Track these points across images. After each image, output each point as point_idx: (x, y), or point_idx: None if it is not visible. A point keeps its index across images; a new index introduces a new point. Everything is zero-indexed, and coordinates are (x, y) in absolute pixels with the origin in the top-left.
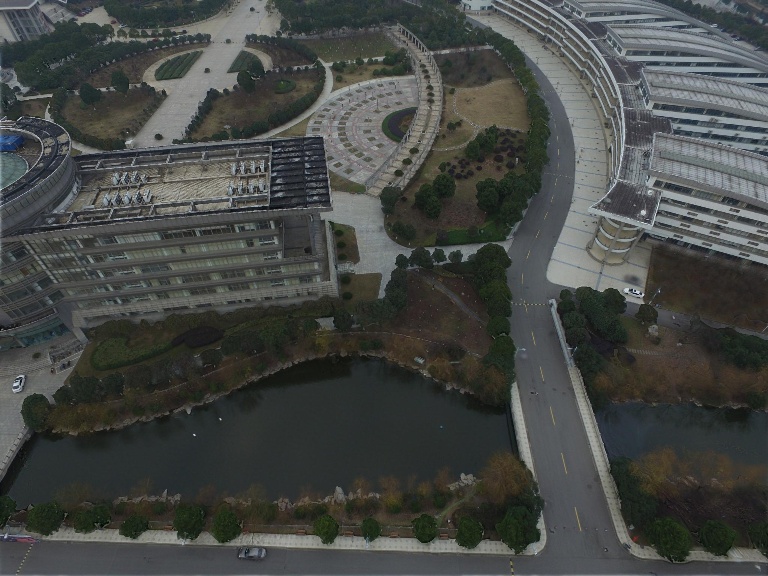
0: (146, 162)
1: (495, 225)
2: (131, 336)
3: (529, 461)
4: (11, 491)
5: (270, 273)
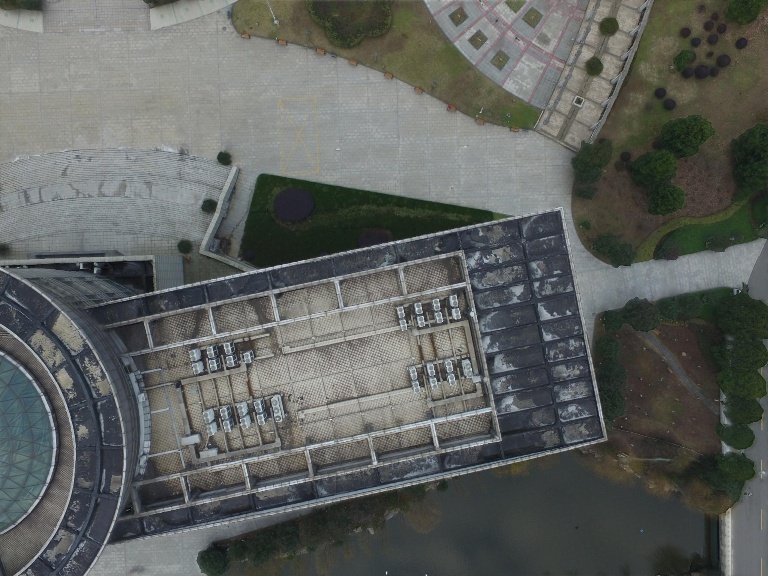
0: None
1: (748, 210)
2: None
3: (728, 569)
4: None
5: None
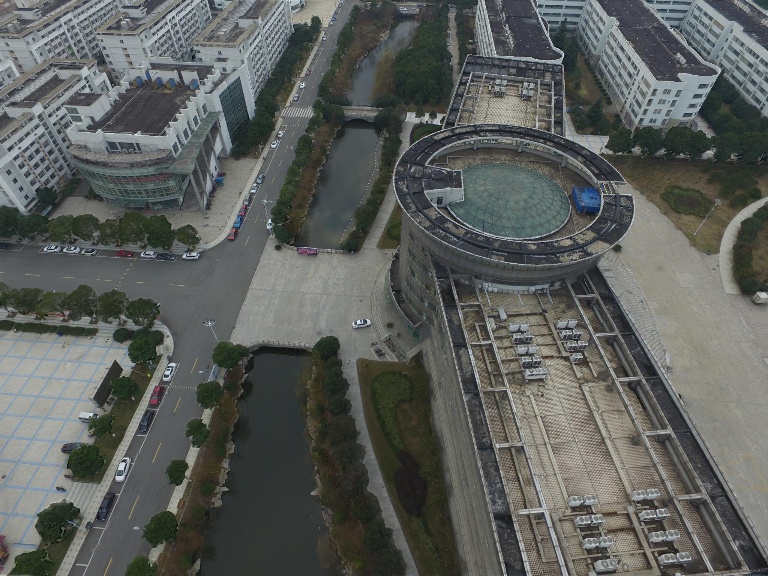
0: (620, 349)
1: None
2: (414, 402)
3: None
4: (273, 355)
5: None
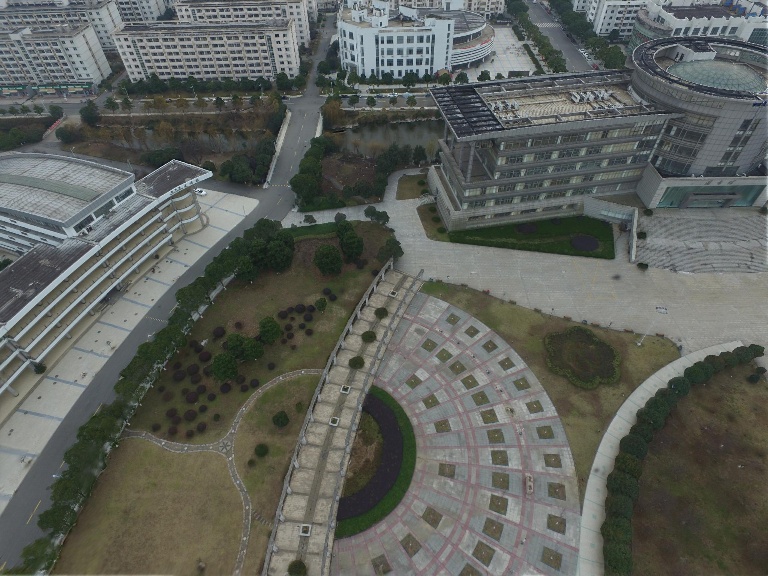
0: None
1: None
2: None
3: (319, 127)
4: None
5: (477, 148)
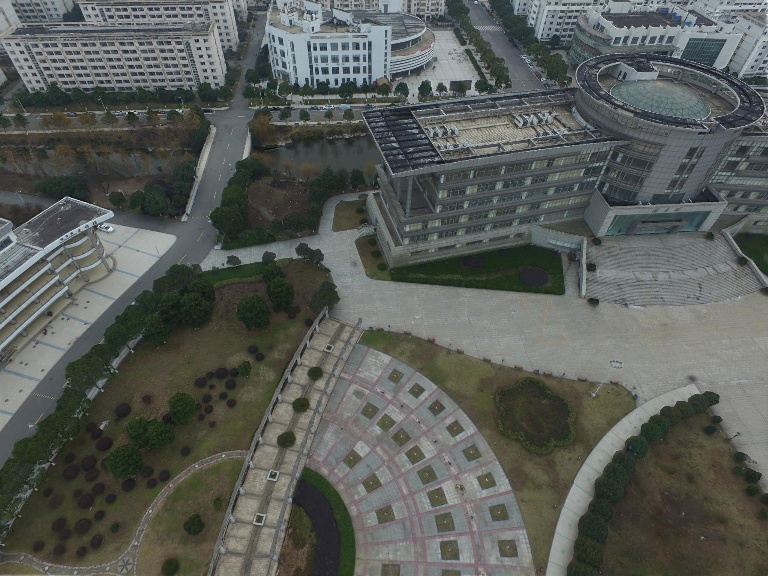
0: None
1: None
2: None
3: (247, 145)
4: None
5: None
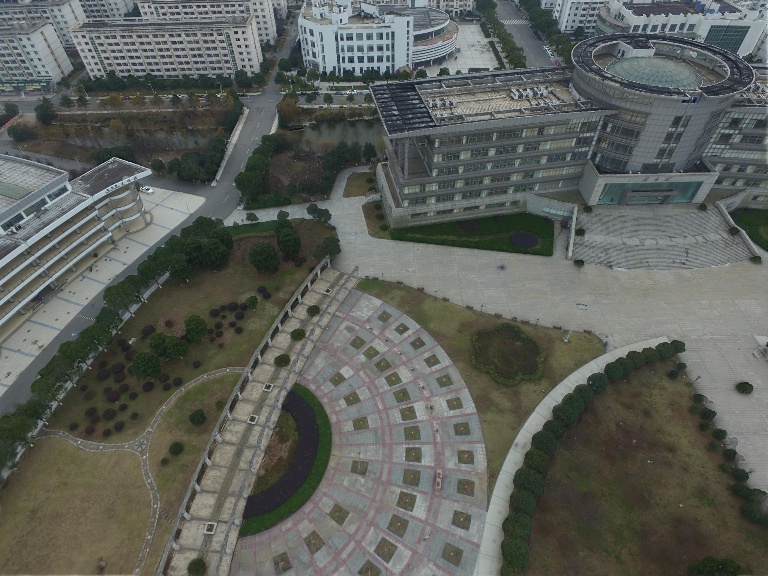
0: None
1: None
2: None
3: None
4: None
5: None
